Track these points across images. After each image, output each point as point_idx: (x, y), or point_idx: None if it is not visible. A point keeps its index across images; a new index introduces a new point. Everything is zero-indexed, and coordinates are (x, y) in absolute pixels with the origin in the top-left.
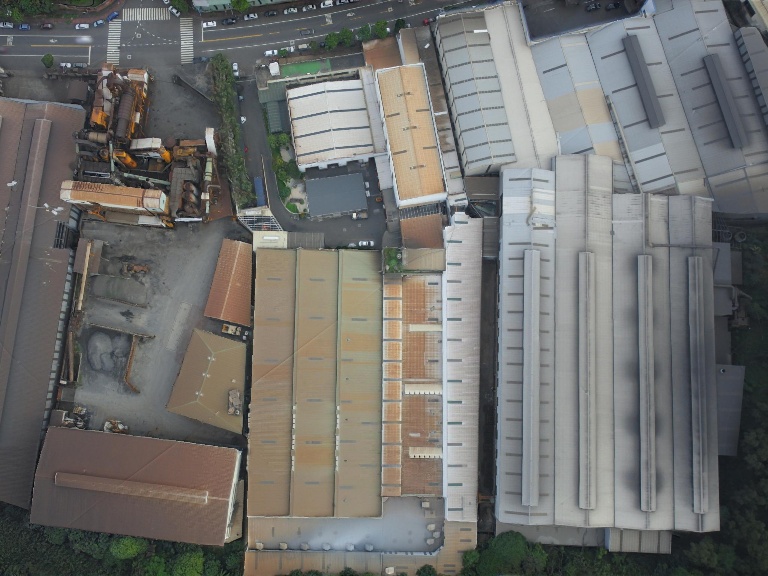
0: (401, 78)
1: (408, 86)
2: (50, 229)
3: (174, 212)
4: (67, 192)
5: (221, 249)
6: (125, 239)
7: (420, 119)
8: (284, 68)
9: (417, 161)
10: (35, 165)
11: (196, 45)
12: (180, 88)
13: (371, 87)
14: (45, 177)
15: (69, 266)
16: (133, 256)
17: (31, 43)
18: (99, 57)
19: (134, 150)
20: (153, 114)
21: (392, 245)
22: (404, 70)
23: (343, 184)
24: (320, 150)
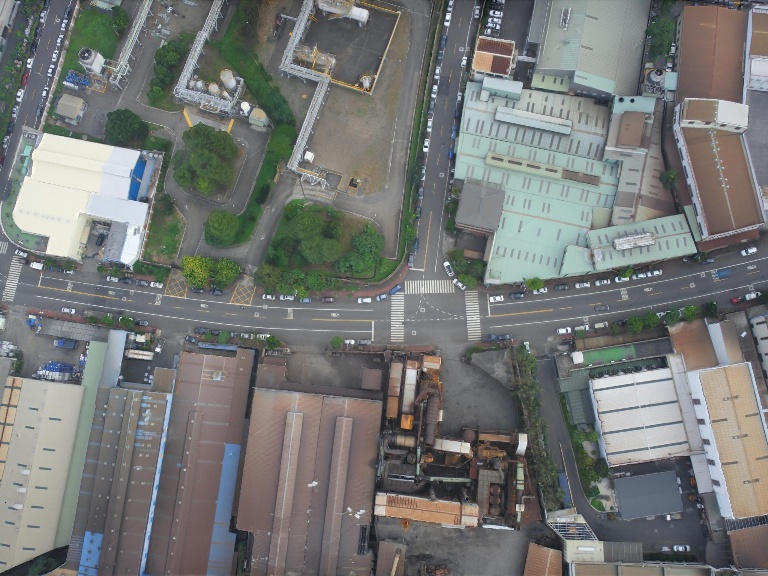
0: (727, 380)
1: (735, 388)
2: (353, 534)
3: (481, 518)
4: (382, 508)
5: (528, 554)
6: (421, 535)
7: (750, 426)
8: (586, 354)
9: (751, 475)
10: (339, 468)
11: (483, 320)
12: (468, 367)
13: (682, 377)
14: (348, 480)
15: (371, 572)
16: (430, 555)
17: (312, 317)
18: (383, 333)
19: (437, 449)
20: (442, 395)
21: (718, 558)
22: (729, 370)
23: (656, 484)
24: (632, 449)
